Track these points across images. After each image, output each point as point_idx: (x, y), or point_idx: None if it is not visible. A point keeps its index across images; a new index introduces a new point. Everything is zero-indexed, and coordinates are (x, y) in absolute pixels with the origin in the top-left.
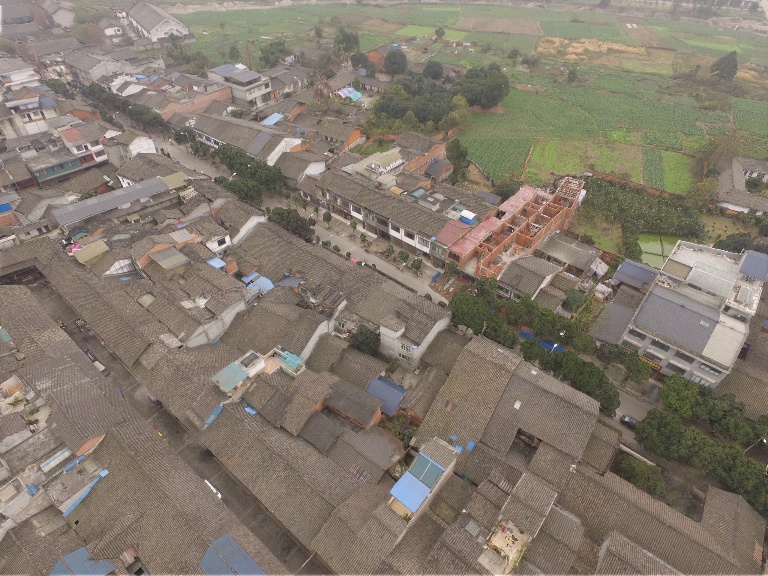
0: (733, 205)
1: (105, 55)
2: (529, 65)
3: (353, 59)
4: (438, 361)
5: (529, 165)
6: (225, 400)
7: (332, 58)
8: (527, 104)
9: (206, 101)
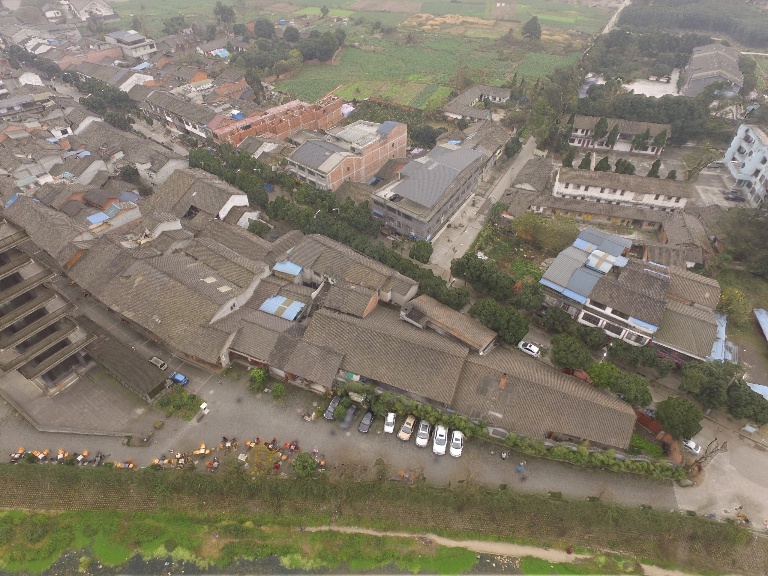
0: (452, 114)
1: (31, 27)
2: (384, 33)
3: (234, 29)
4: None
5: None
6: (20, 192)
7: (220, 29)
8: (361, 59)
9: (99, 56)
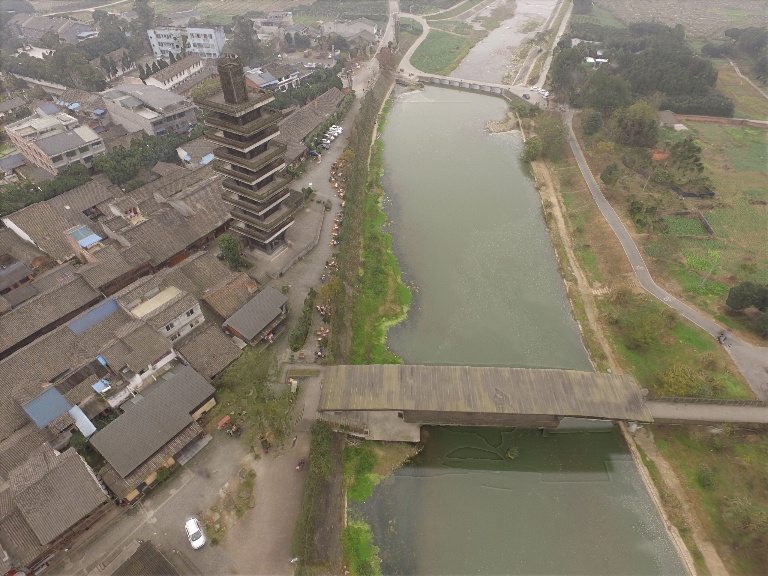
0: None
1: None
2: None
3: None
4: (5, 248)
5: None
6: None
7: None
8: None
9: None
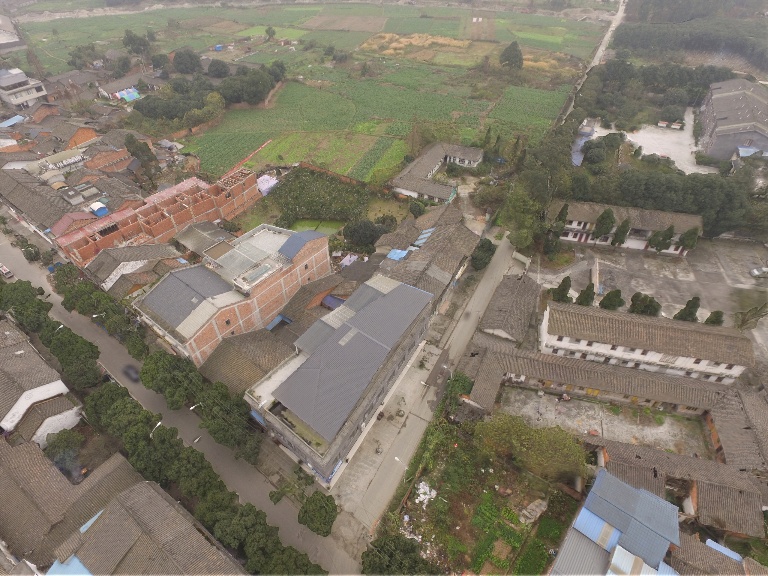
0: (404, 190)
1: None
2: (336, 61)
3: (152, 61)
4: None
5: (252, 158)
6: None
7: None
8: (302, 99)
9: None
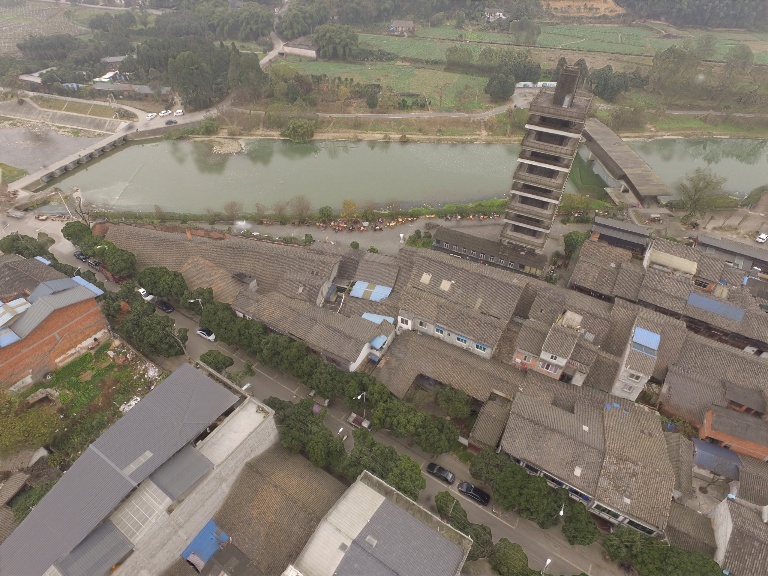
0: None
1: None
2: None
3: None
4: (687, 512)
5: None
6: None
7: None
8: None
9: None
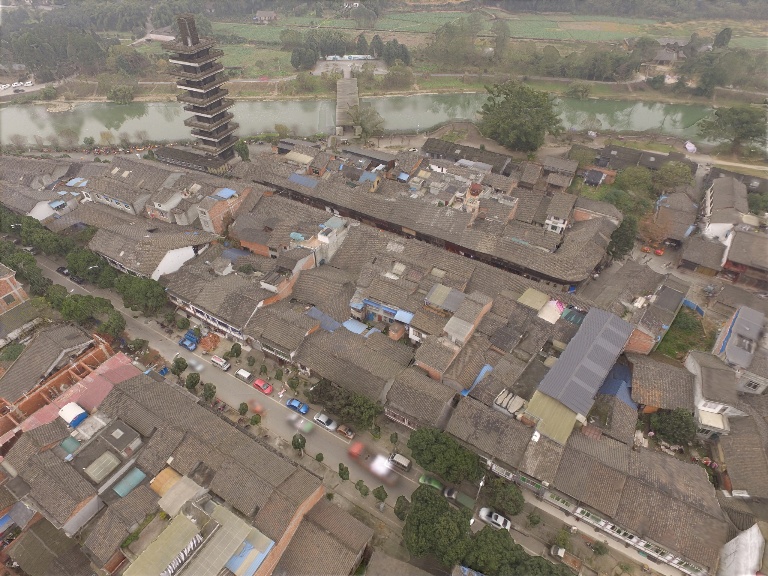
0: None
1: None
2: None
3: None
4: None
5: None
6: None
7: None
8: None
9: None
